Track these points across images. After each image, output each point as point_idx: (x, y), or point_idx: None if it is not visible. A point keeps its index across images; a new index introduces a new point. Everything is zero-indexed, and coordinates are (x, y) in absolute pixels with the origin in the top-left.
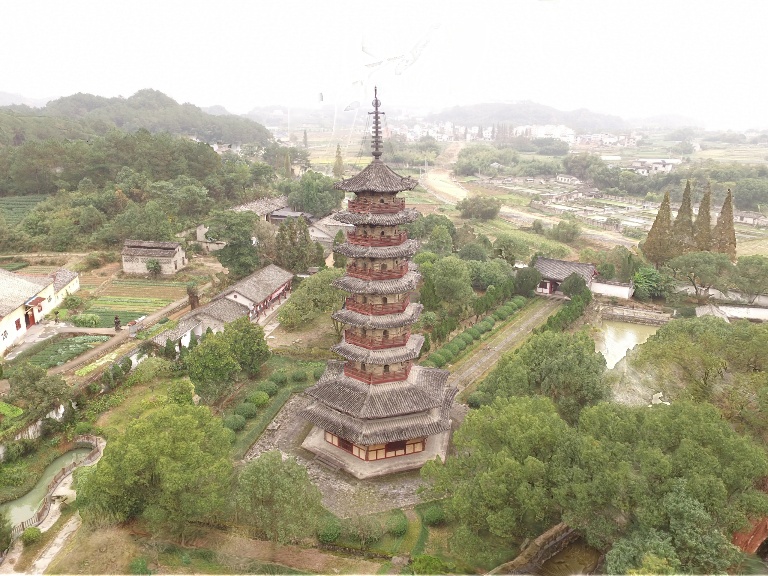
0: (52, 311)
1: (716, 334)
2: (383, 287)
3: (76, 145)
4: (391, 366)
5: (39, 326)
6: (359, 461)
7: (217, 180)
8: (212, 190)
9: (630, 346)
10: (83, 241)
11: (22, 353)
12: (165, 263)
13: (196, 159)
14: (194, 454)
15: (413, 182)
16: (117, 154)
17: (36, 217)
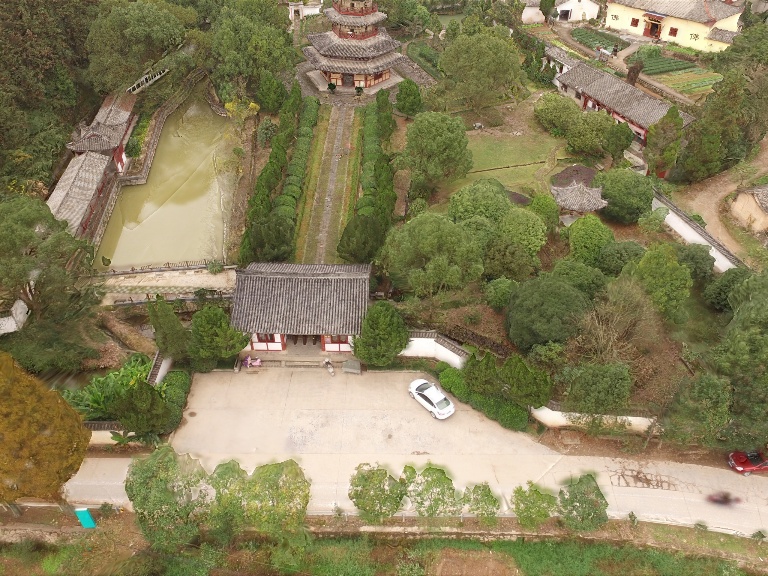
0: (688, 47)
1: None
2: None
3: None
4: None
5: None
6: None
7: None
8: None
9: (186, 234)
10: None
11: None
12: None
13: None
14: None
15: None
16: None
17: None
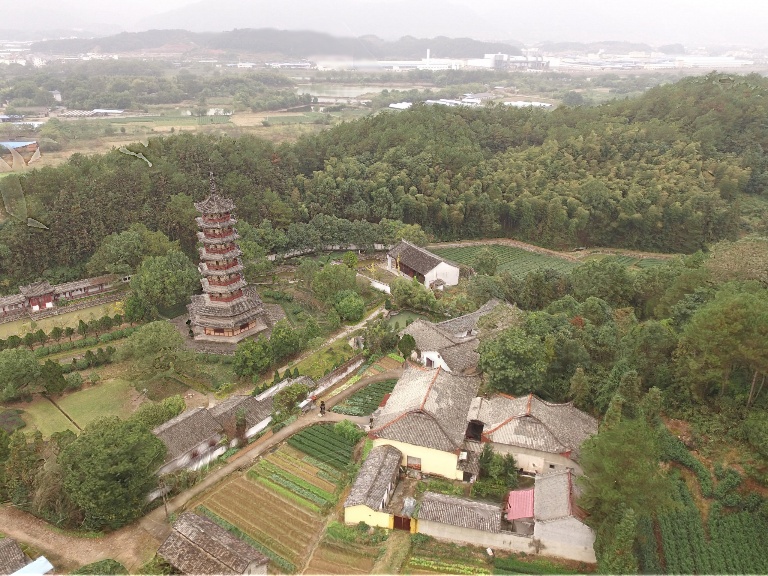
0: None
1: None
2: None
3: None
4: None
5: None
6: None
7: None
8: None
9: None
10: None
11: None
12: None
13: None
14: None
15: None
16: None
17: None
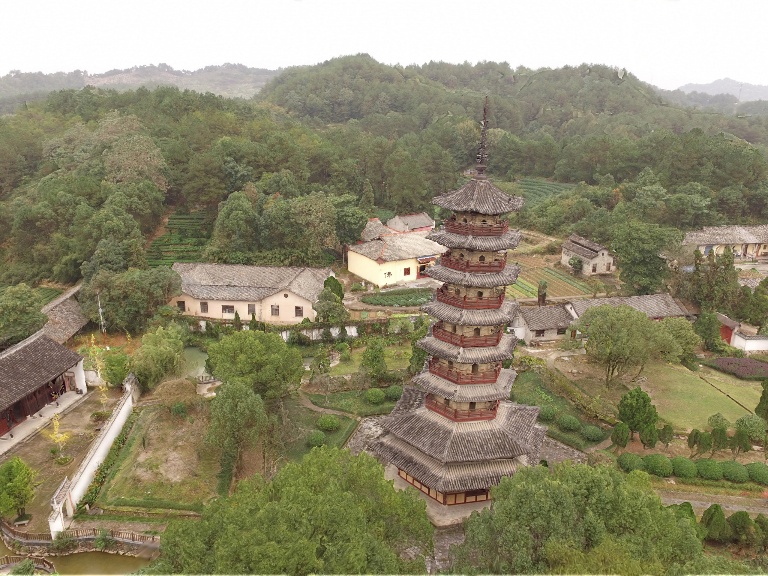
0: None
1: None
2: (442, 311)
3: (621, 143)
4: (452, 401)
5: (430, 279)
6: (397, 471)
7: (737, 193)
8: (725, 203)
9: None
10: (565, 229)
11: (392, 291)
12: (586, 263)
13: (724, 166)
14: (239, 365)
15: (512, 206)
16: (651, 154)
17: (549, 202)
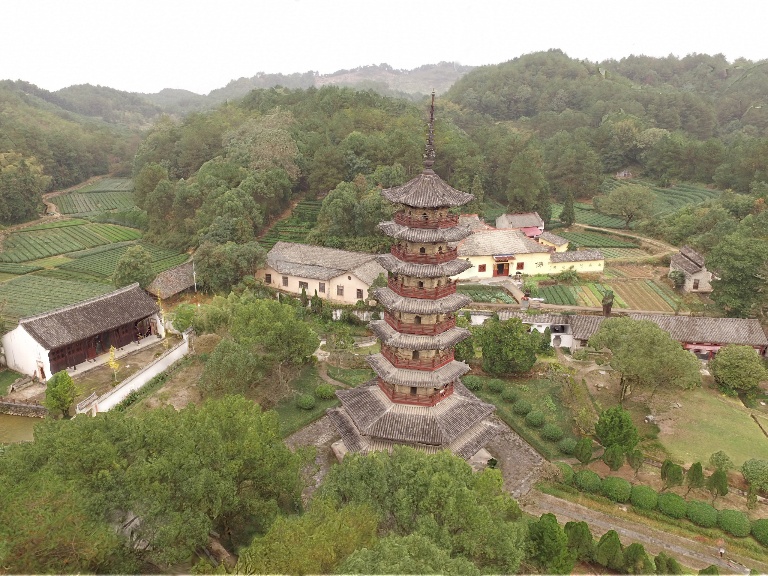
0: (537, 274)
1: (343, 570)
2: (388, 296)
3: None
4: None
5: (507, 278)
6: None
7: None
8: None
9: None
10: (692, 241)
11: (462, 285)
12: (688, 278)
13: None
14: None
15: (444, 201)
16: None
17: (685, 210)
